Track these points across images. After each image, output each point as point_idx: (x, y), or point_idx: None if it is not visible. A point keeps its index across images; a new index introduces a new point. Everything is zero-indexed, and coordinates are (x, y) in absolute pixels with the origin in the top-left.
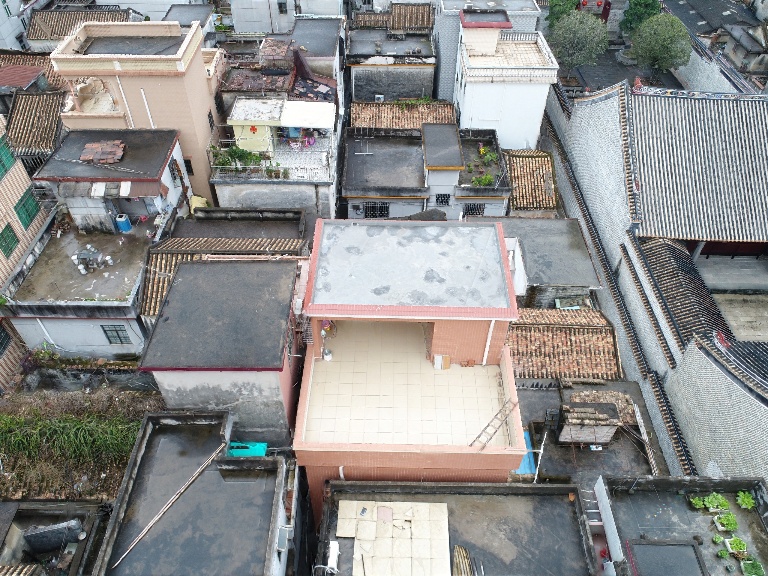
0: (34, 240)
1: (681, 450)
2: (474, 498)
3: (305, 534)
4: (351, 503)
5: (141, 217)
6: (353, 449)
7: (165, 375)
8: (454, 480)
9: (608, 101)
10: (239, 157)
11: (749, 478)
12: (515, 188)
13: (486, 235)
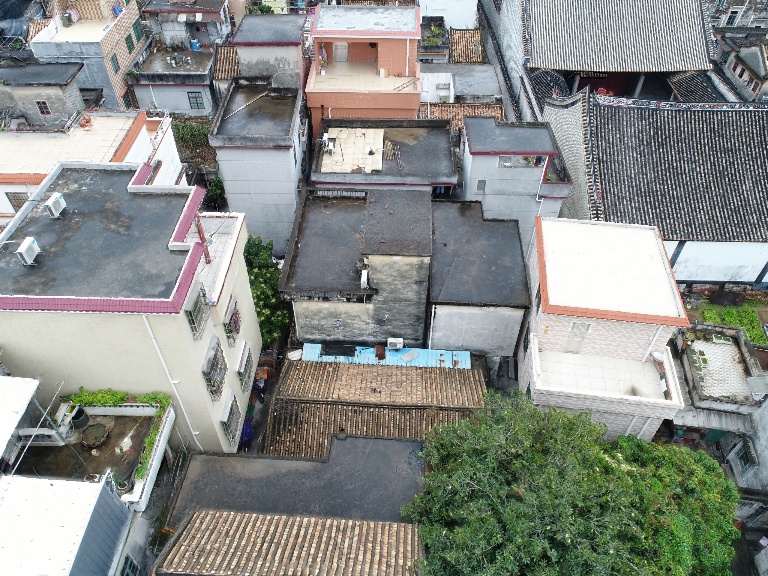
0: (142, 50)
1: None
2: (398, 129)
3: (311, 154)
4: (335, 129)
5: (205, 43)
6: (335, 91)
7: (243, 51)
8: (387, 118)
9: None
10: (266, 11)
11: None
12: (454, 50)
13: (410, 11)
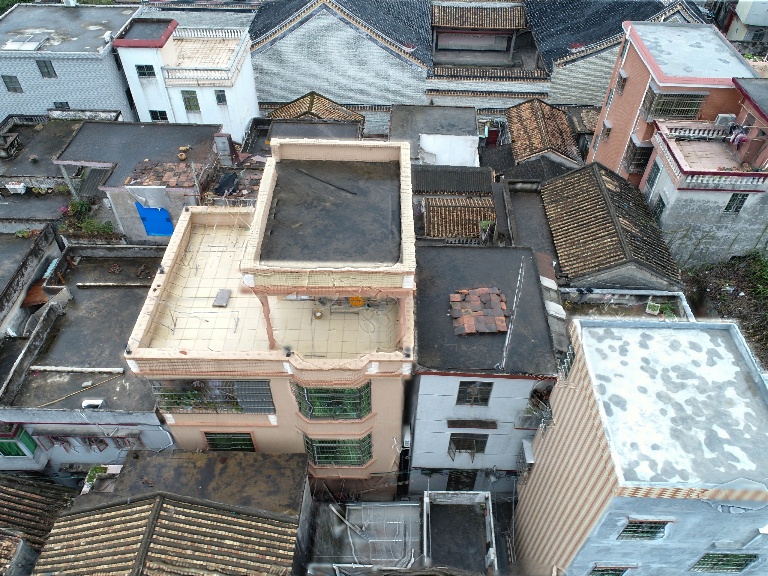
0: None
1: None
2: None
3: None
4: None
5: None
6: None
7: None
8: None
9: (309, 22)
10: None
11: None
12: None
13: (640, 27)
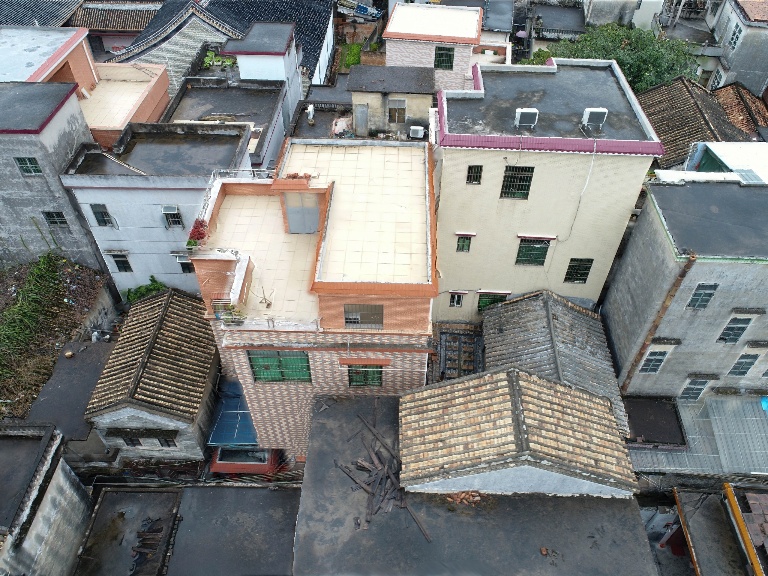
0: None
1: None
2: (175, 114)
3: None
4: None
5: None
6: (134, 110)
7: (45, 137)
8: None
9: None
10: None
11: (202, 44)
12: None
13: (8, 31)
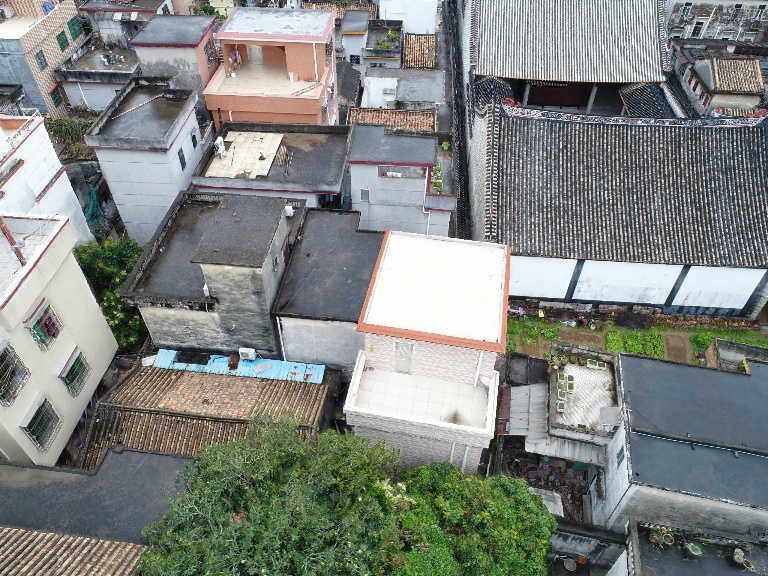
0: (78, 47)
1: (458, 172)
2: (299, 134)
3: None
4: (235, 132)
5: None
6: (233, 94)
7: (141, 52)
8: None
9: None
10: (210, 12)
11: None
12: (407, 54)
13: (325, 15)
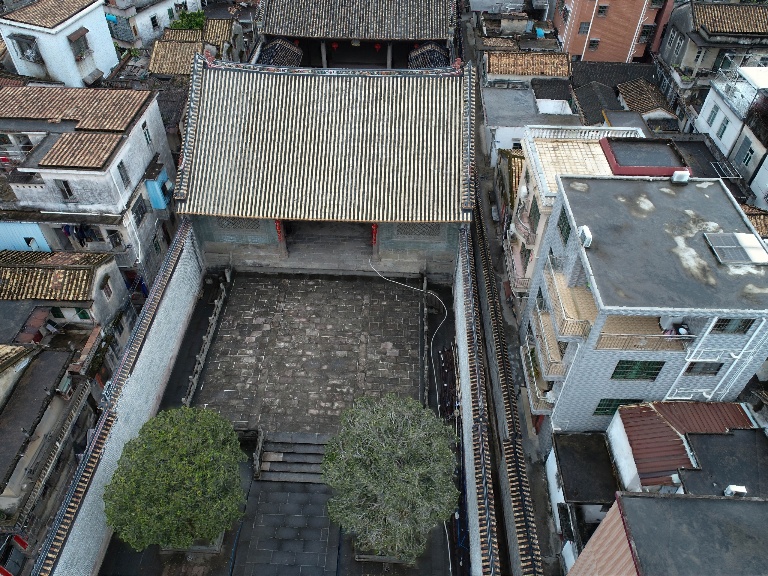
0: None
1: None
2: None
3: None
4: None
5: None
6: None
7: None
8: None
9: None
10: None
11: None
12: None
13: None
